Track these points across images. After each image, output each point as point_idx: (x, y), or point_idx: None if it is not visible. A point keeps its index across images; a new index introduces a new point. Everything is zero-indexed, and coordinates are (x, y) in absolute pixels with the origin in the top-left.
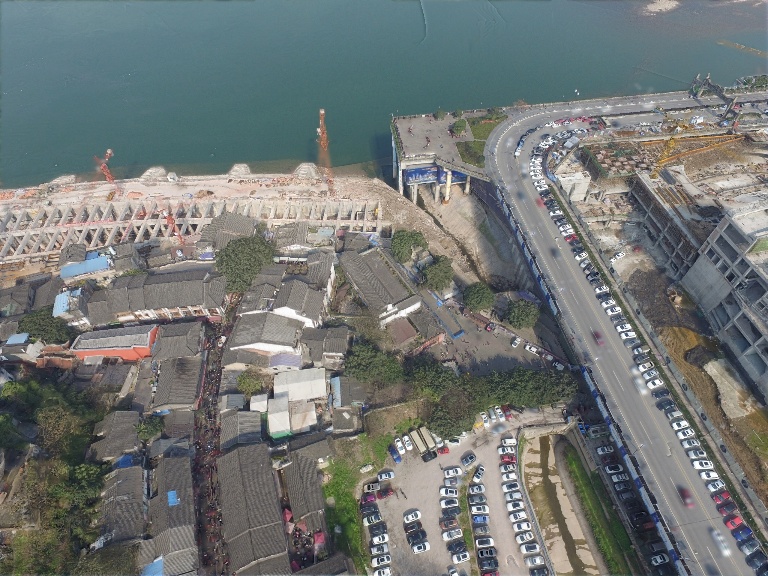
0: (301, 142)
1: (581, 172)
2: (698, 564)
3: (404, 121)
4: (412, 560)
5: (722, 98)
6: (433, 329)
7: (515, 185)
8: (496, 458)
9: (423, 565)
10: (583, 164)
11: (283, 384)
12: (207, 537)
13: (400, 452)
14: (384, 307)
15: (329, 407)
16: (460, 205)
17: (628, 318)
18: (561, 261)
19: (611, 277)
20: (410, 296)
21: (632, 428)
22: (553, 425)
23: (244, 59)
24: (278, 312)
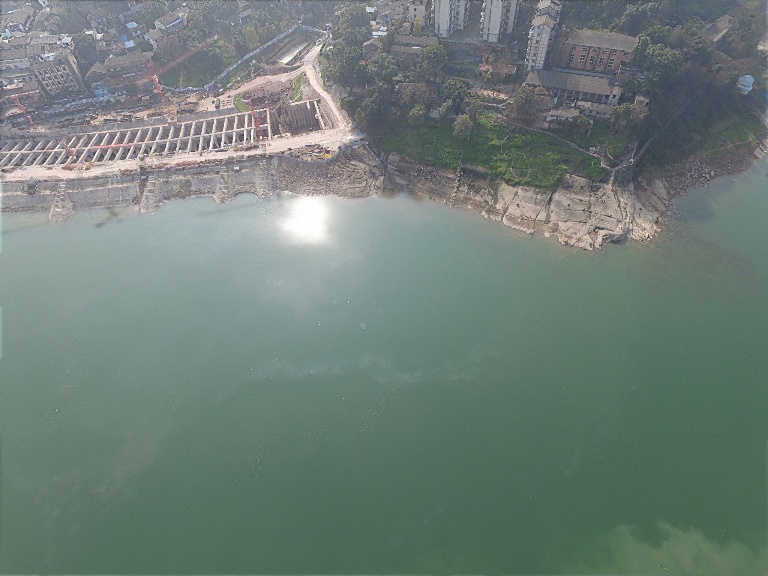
0: None
1: None
2: None
3: None
4: None
5: None
6: None
7: None
8: None
9: None
10: None
11: None
12: None
13: None
14: None
15: None
16: None
17: None
18: None
19: None
20: None
21: None
22: None
23: None
24: None
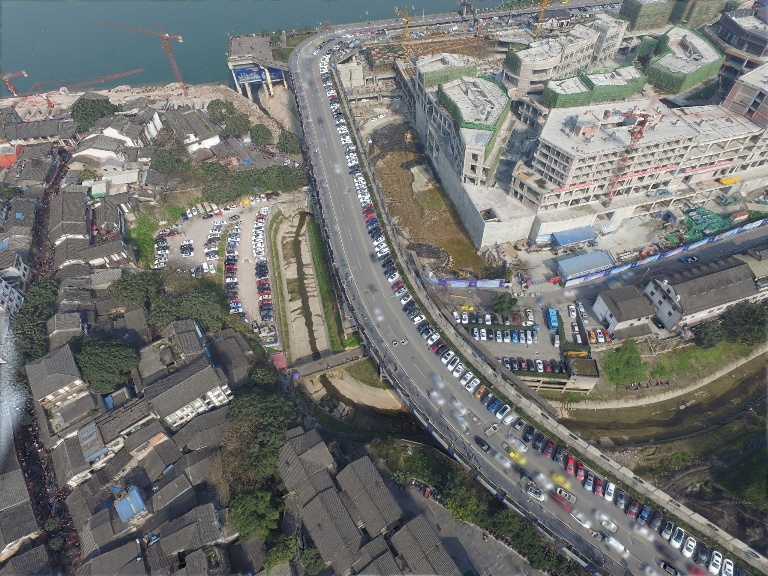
0: (175, 70)
1: (356, 62)
2: (339, 235)
3: (238, 39)
4: (181, 261)
5: (471, 12)
6: (225, 152)
7: (306, 71)
8: (254, 218)
9: (187, 262)
10: (368, 62)
11: (109, 176)
12: (44, 243)
13: (188, 215)
14: (186, 135)
15: (138, 186)
16: (281, 97)
17: (351, 134)
18: (320, 109)
19: (350, 115)
20: (209, 132)
21: (329, 184)
22: (297, 201)
23: (141, 19)
24: (106, 134)
